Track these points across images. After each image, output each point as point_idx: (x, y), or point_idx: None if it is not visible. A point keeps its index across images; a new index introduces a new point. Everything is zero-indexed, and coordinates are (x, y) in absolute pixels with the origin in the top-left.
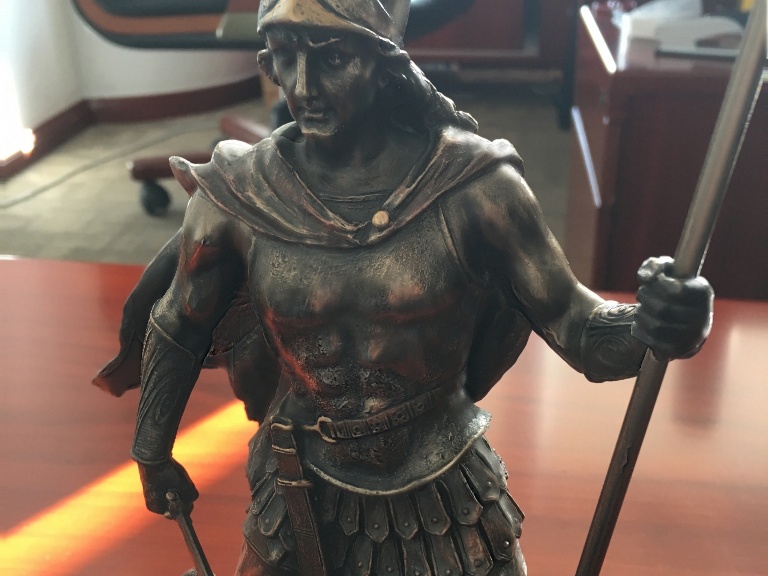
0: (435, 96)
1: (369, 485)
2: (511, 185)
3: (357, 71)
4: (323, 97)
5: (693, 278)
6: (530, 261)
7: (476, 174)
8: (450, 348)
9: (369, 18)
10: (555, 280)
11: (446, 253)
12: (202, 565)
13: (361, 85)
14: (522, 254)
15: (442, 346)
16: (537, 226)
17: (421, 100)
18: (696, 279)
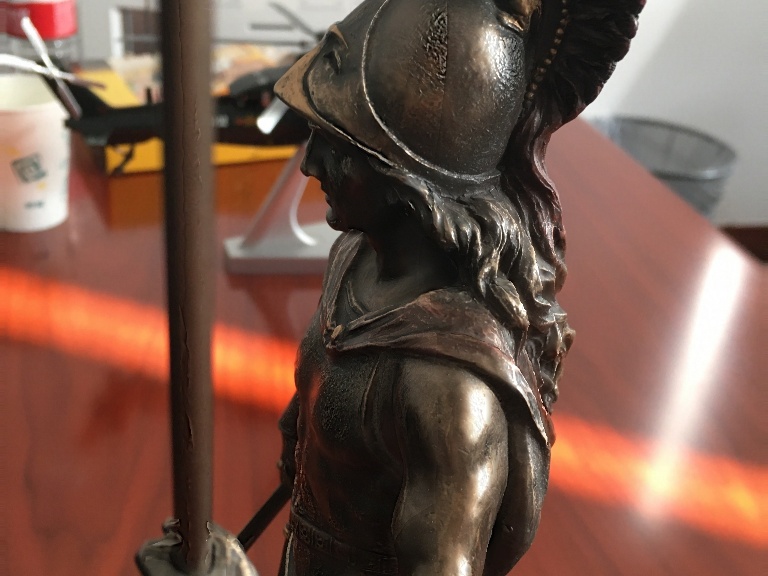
0: (473, 251)
1: (291, 574)
2: (431, 390)
3: (347, 171)
4: (325, 181)
5: (176, 567)
6: (407, 488)
7: (413, 352)
8: (356, 514)
9: (345, 119)
10: (413, 531)
11: (358, 410)
12: (245, 526)
13: (352, 188)
14: (407, 474)
15: (349, 504)
16: (435, 458)
17: (436, 243)
18: (180, 573)
